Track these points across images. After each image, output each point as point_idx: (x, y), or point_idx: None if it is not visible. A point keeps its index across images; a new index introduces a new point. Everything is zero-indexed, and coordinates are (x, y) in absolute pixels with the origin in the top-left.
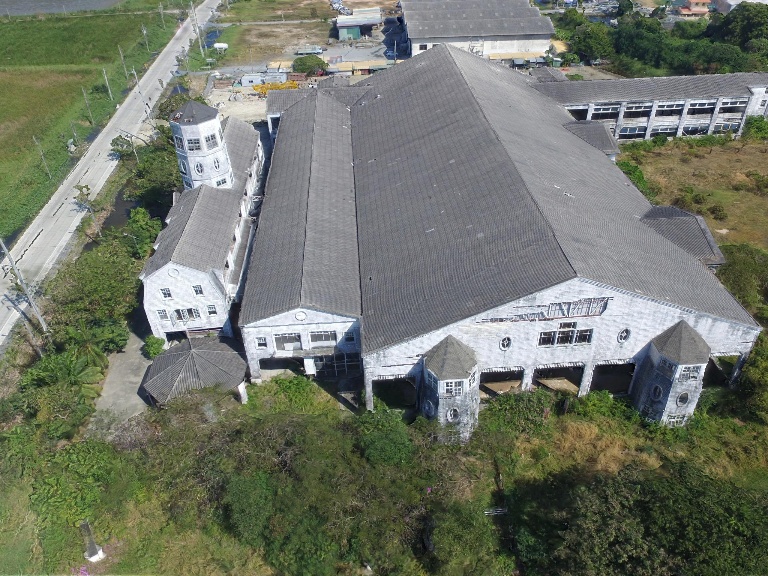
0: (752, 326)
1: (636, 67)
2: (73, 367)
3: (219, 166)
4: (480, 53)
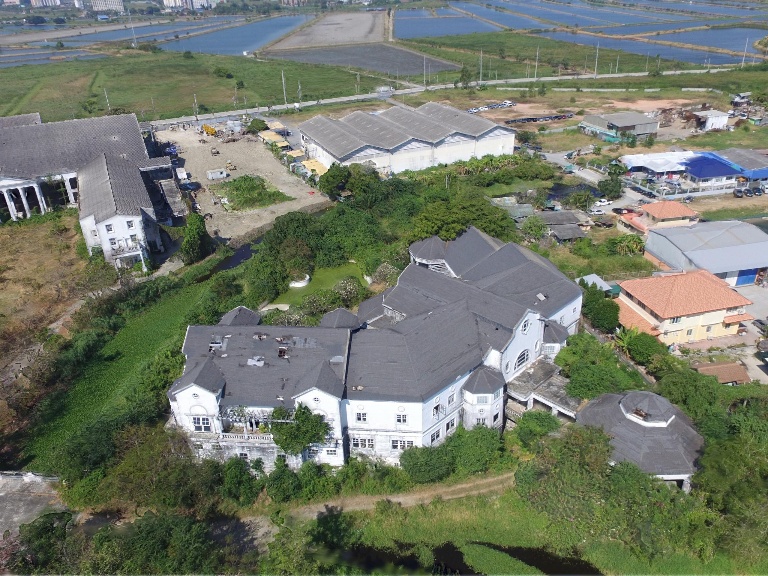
0: None
1: None
2: None
3: None
4: None
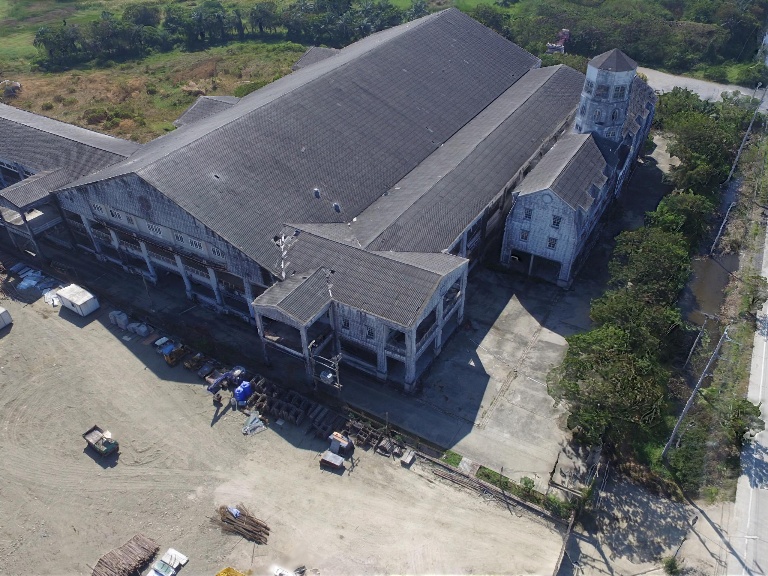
0: None
1: None
2: None
3: None
4: None
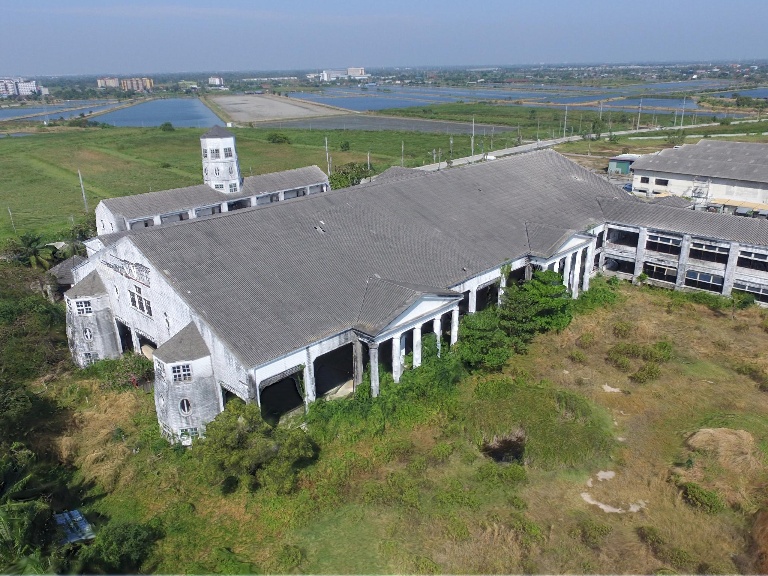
0: (237, 358)
1: None
2: (31, 239)
3: (220, 174)
4: (704, 195)
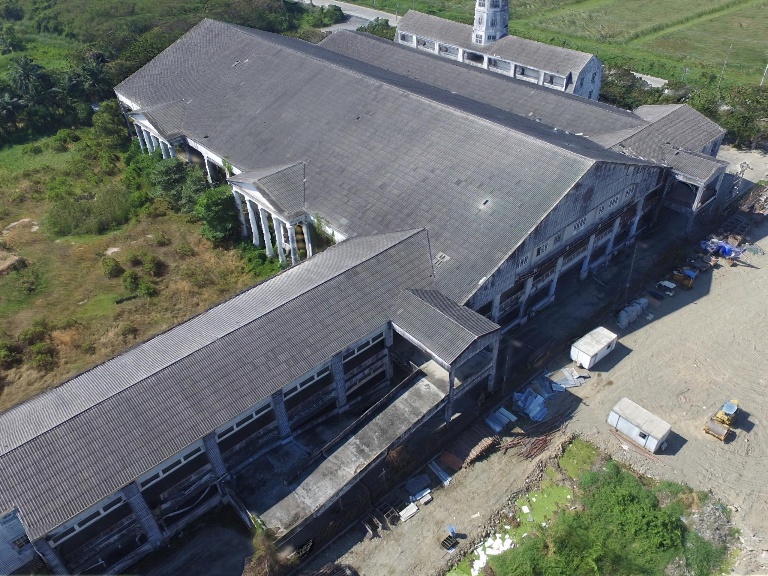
0: None
1: None
2: None
3: None
4: None
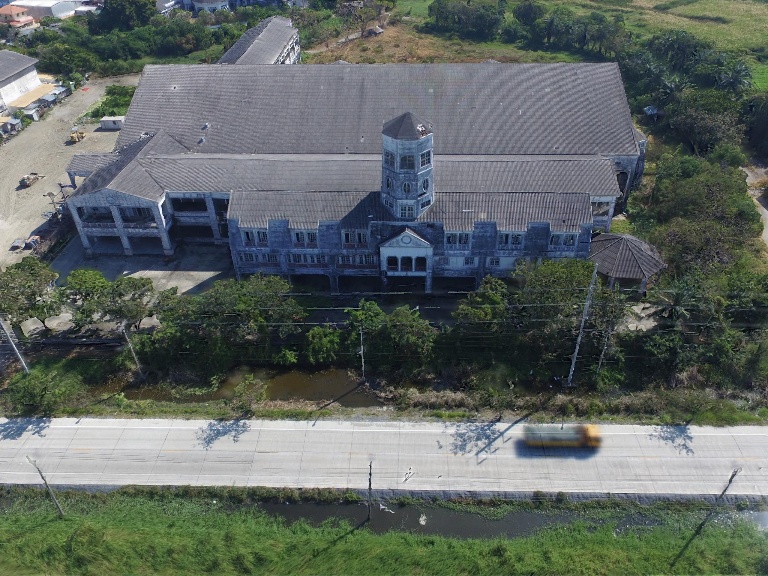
0: None
1: (125, 65)
2: None
3: None
4: (3, 107)
